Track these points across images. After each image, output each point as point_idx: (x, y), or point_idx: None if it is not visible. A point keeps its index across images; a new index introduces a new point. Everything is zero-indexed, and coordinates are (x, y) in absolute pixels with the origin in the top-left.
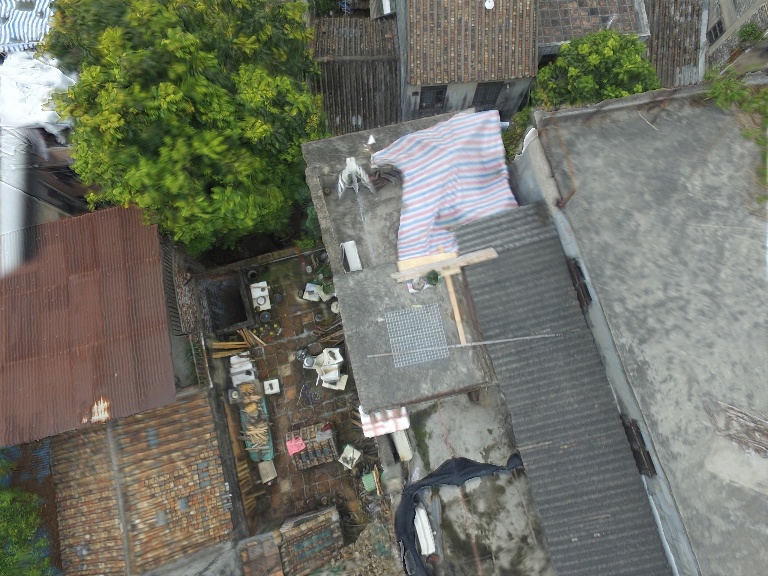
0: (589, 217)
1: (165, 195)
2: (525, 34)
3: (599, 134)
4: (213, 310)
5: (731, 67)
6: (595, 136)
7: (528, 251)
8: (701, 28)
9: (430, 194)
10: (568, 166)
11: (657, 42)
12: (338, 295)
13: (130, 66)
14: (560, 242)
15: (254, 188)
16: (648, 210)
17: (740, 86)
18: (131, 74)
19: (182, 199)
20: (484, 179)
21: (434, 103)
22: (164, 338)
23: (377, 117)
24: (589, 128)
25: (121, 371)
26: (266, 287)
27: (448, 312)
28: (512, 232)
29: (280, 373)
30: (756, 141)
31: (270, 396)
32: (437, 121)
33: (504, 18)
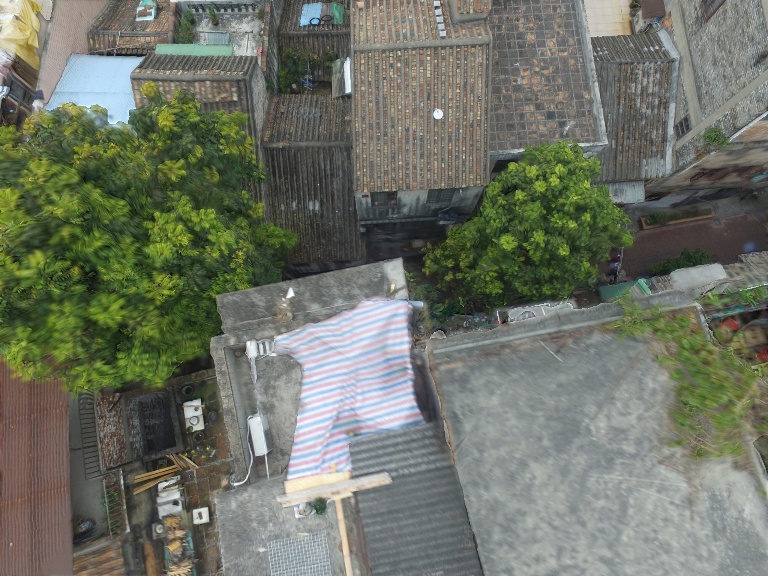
0: (479, 469)
1: (62, 362)
2: (476, 143)
3: (496, 367)
4: (147, 424)
5: (698, 163)
6: (492, 369)
7: (424, 479)
8: (668, 121)
9: (329, 394)
10: (459, 407)
11: (623, 134)
12: (219, 519)
13: (13, 245)
14: (457, 473)
15: (170, 334)
16: (546, 459)
17: (653, 313)
18: (16, 251)
19: (83, 362)
20: (388, 377)
21: (387, 202)
22: (65, 502)
23: (335, 202)
24: (486, 360)
25: (17, 540)
26: (200, 406)
27: (337, 542)
28: (408, 455)
29: (211, 499)
30: (669, 375)
31: (200, 525)
32: (361, 273)
33: (454, 128)
